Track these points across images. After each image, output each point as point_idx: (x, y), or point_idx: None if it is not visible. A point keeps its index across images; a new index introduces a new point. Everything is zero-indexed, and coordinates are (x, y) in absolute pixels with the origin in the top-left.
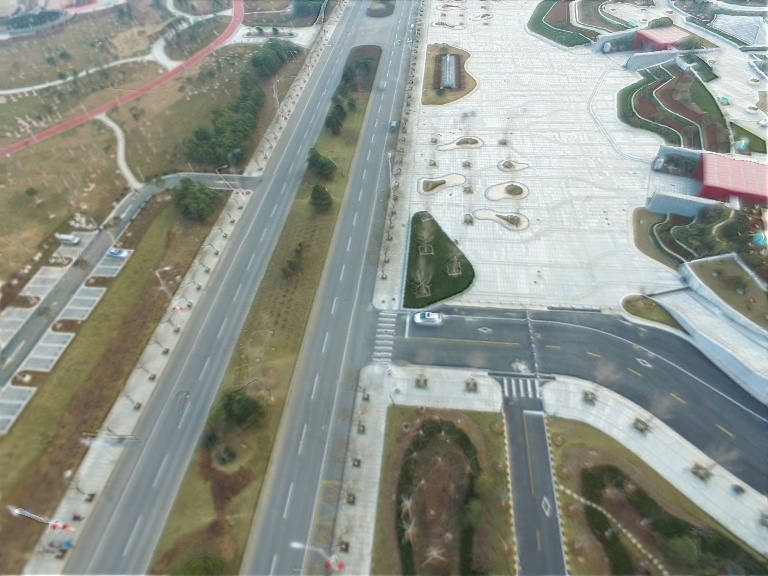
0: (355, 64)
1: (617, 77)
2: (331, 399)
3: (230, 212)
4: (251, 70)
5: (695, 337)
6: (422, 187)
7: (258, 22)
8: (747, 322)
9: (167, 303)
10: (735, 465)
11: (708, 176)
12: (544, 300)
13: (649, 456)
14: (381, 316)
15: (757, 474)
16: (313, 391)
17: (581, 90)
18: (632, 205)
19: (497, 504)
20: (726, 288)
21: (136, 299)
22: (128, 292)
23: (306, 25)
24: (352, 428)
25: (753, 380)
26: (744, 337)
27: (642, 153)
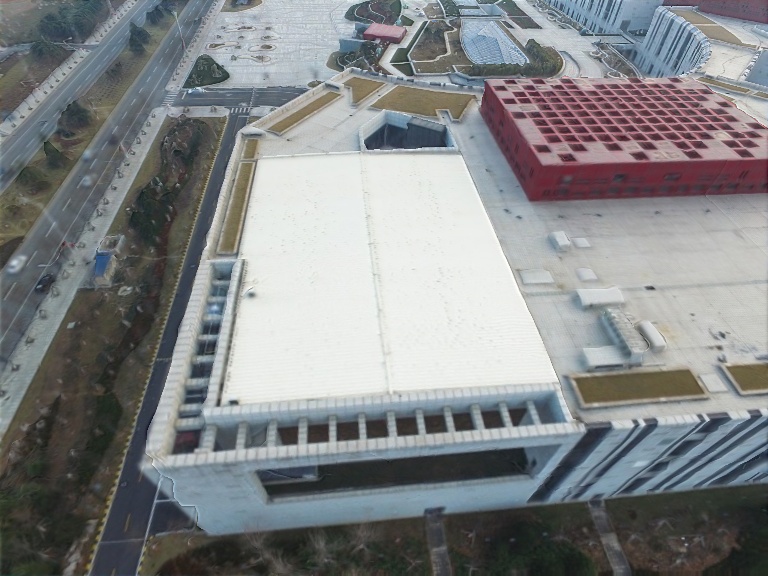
0: None
1: (356, 0)
2: (133, 118)
3: (73, 57)
4: None
5: None
6: (208, 46)
7: None
8: None
9: (30, 93)
10: None
11: (368, 30)
12: (266, 85)
13: None
14: (169, 93)
15: None
16: (123, 117)
17: (330, 6)
18: (333, 51)
19: (213, 137)
20: None
21: (8, 92)
22: (2, 90)
23: None
24: (144, 125)
25: None
26: None
27: (351, 32)
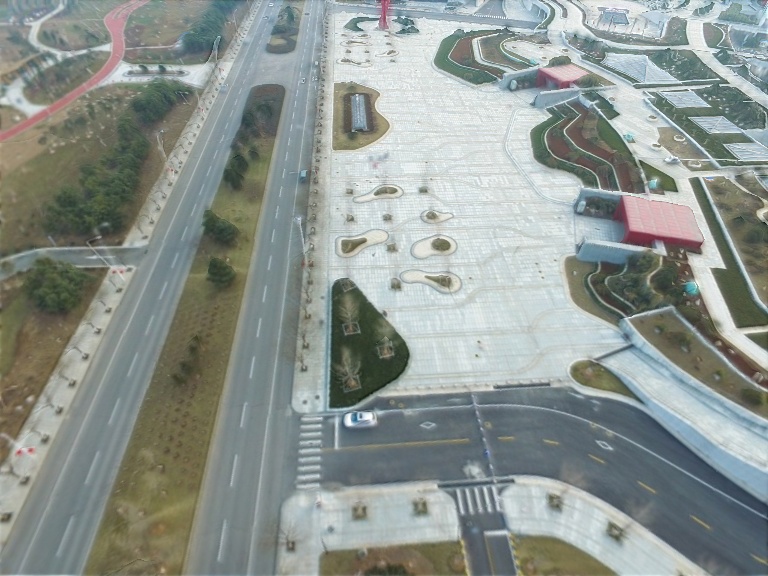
0: (256, 106)
1: (527, 115)
2: (244, 556)
3: (104, 299)
4: (132, 115)
5: (650, 406)
6: (341, 248)
7: (142, 59)
8: (698, 384)
9: (12, 440)
10: (720, 567)
11: (632, 221)
12: (489, 377)
13: (630, 572)
14: (303, 422)
15: (743, 575)
16: (220, 548)
17: (495, 129)
18: (562, 254)
19: None
20: (671, 346)
21: None
22: None
23: (198, 62)
24: None
25: (717, 454)
26: (698, 402)
27: (563, 195)
